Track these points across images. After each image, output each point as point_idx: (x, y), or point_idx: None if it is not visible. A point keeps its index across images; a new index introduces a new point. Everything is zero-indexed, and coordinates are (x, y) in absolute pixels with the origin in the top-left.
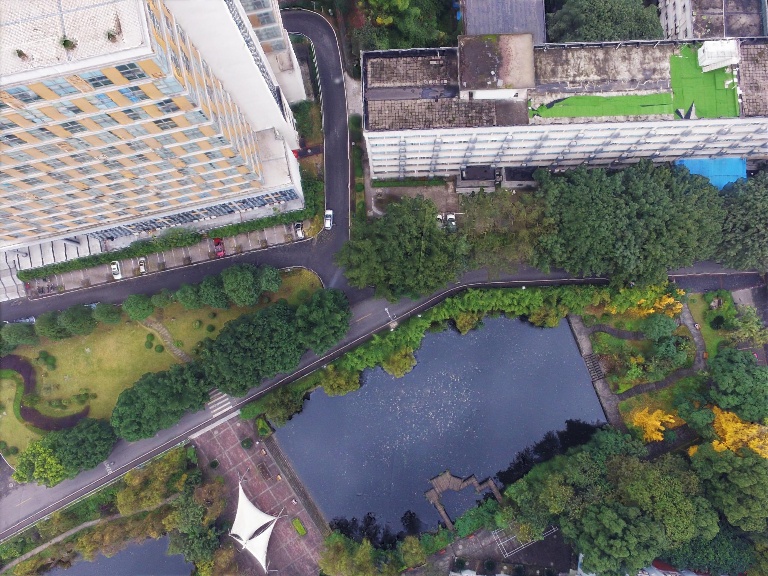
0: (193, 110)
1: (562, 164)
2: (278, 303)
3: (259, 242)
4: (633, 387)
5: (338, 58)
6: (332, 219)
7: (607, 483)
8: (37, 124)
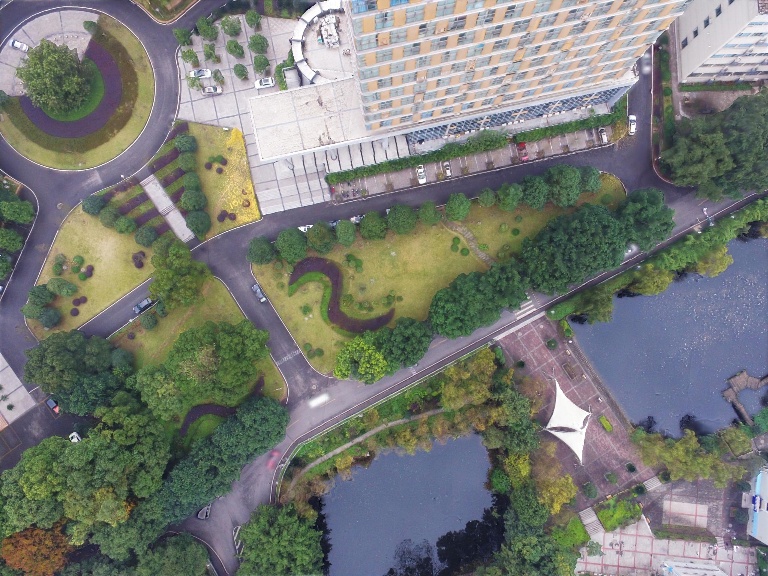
0: None
1: None
2: None
3: (561, 147)
4: None
5: None
6: None
7: None
8: None
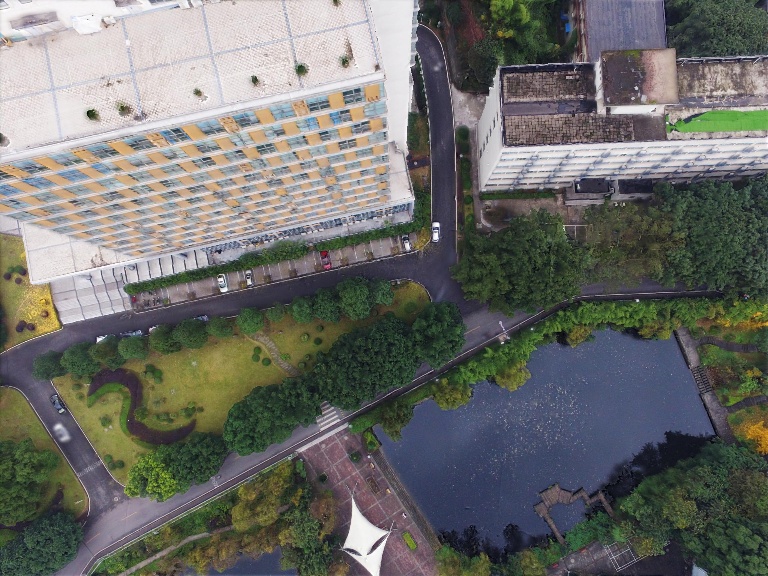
0: (381, 131)
1: (676, 176)
2: (387, 316)
3: (365, 255)
4: (743, 400)
5: (445, 70)
6: (439, 231)
7: (731, 498)
8: (237, 147)
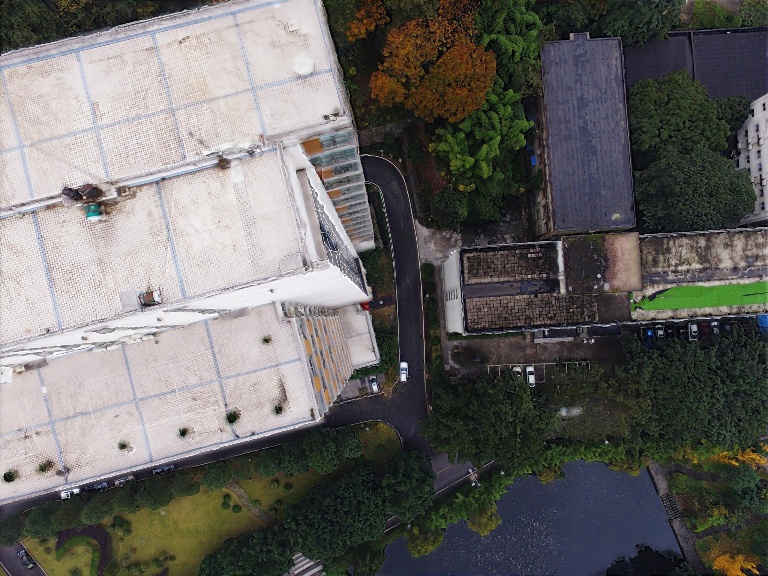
0: None
1: None
2: (357, 460)
3: None
4: (710, 526)
5: (408, 206)
6: (407, 372)
7: None
8: None
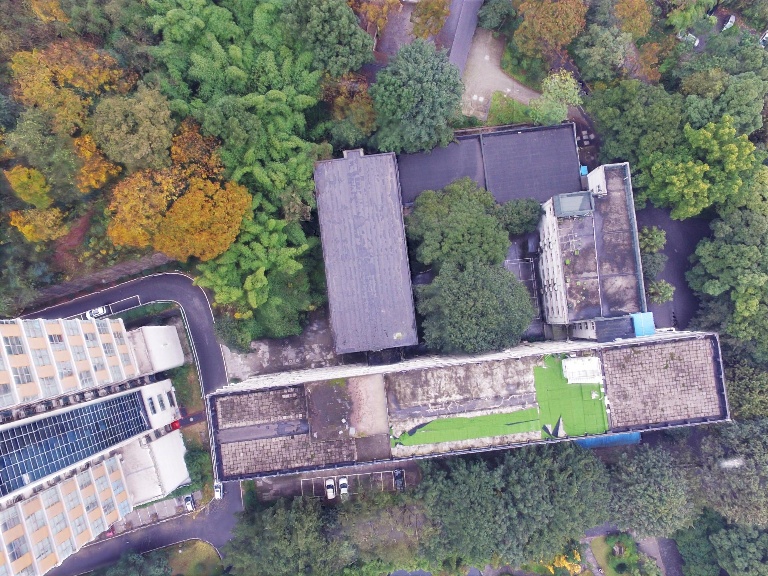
0: None
1: None
2: None
3: (149, 517)
4: None
5: (211, 321)
6: (222, 488)
7: None
8: None
